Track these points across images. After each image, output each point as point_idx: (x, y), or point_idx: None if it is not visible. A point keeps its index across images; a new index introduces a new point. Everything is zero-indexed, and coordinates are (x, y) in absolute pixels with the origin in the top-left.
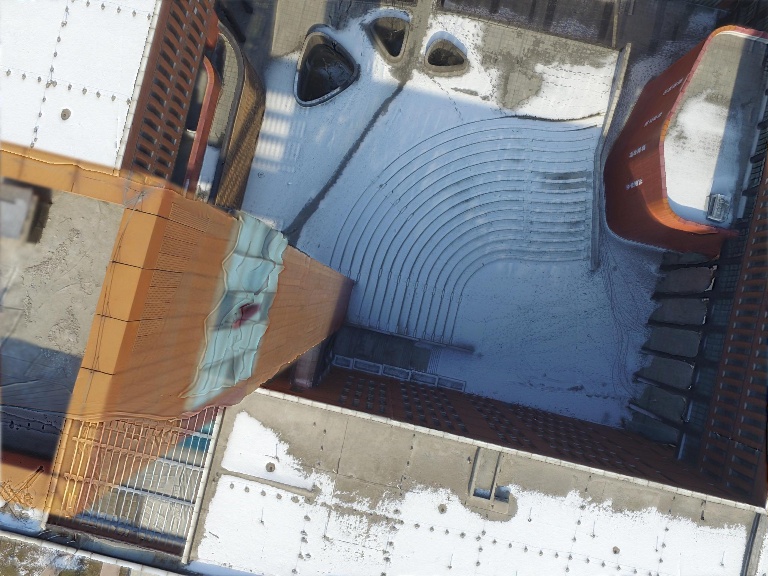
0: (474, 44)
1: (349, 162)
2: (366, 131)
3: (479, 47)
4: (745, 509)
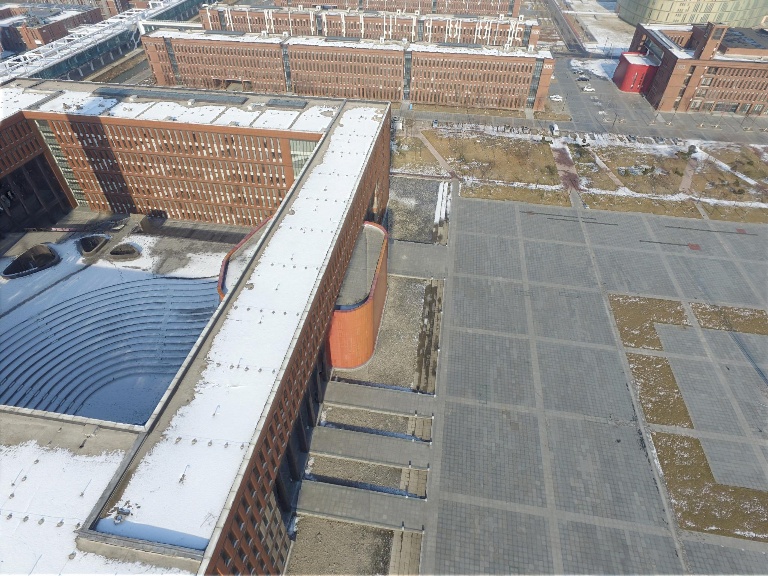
0: (149, 247)
1: (20, 307)
2: (45, 290)
3: (152, 248)
4: (123, 428)
